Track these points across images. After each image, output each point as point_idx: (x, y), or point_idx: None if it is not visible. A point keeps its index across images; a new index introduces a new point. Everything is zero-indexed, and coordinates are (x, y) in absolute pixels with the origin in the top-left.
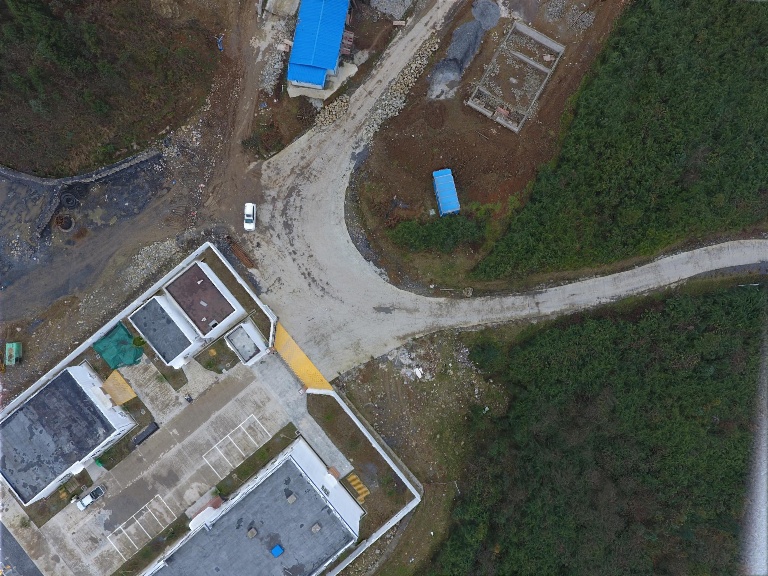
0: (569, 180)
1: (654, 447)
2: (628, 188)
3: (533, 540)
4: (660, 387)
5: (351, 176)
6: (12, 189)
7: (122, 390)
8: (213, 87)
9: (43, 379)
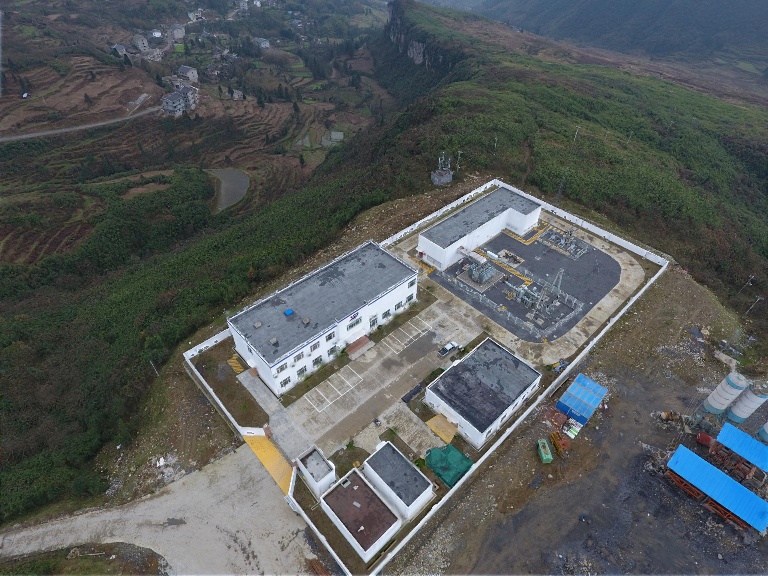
0: None
1: None
2: None
3: None
4: None
5: None
6: None
7: (439, 427)
8: None
9: (508, 429)
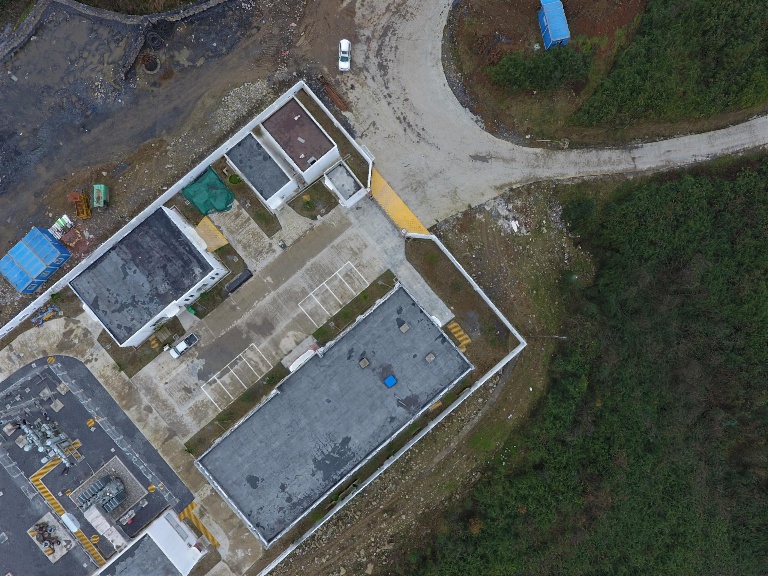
0: (680, 11)
1: (739, 323)
2: (735, 27)
3: (624, 408)
4: (749, 256)
5: (449, 13)
6: (93, 30)
7: (213, 237)
8: None
9: (133, 222)
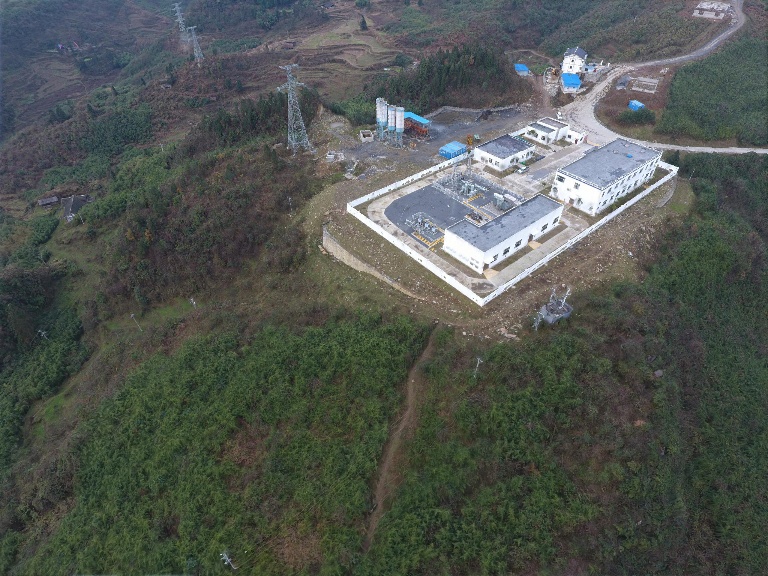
0: None
1: None
2: None
3: None
4: None
5: (594, 110)
6: None
7: None
8: (532, 96)
9: None
